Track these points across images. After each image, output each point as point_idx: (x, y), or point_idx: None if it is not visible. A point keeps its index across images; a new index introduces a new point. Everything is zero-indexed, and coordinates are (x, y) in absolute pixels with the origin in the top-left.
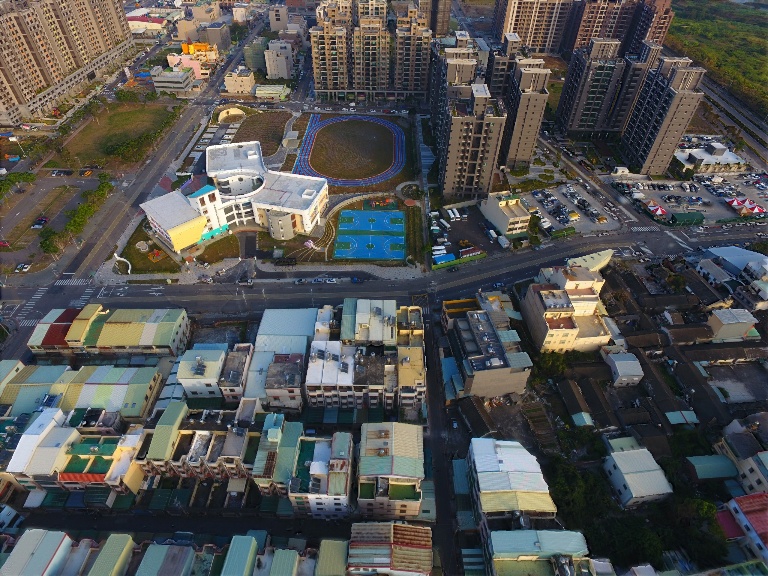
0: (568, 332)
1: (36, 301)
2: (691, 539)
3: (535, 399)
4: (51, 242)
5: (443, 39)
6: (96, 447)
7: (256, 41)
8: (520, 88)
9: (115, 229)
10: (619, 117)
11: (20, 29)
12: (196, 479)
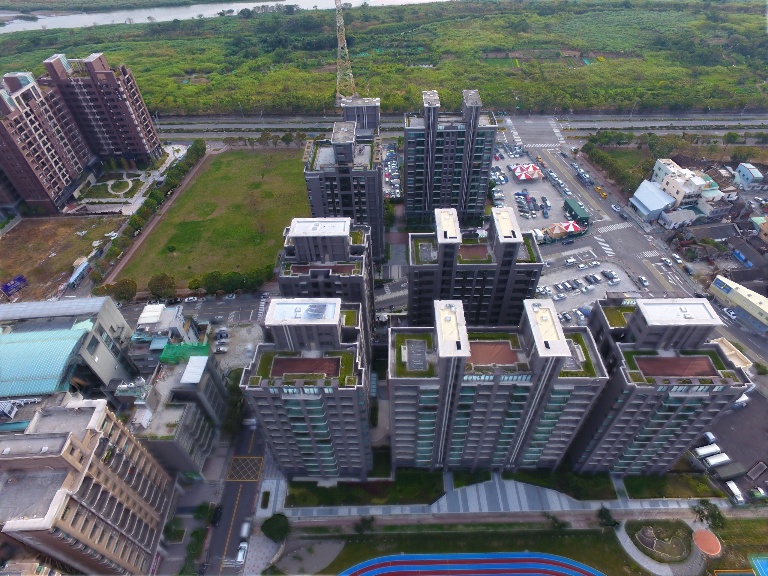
0: None
1: None
2: None
3: None
4: None
5: None
6: None
7: None
8: (515, 263)
9: None
10: None
11: None
12: None
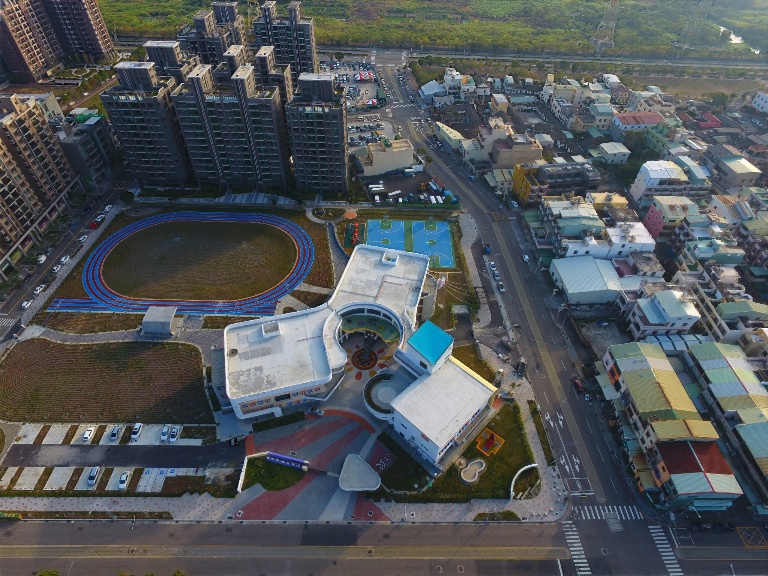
0: None
1: None
2: (640, 145)
3: None
4: None
5: None
6: None
7: None
8: (269, 73)
9: (431, 543)
10: None
11: None
12: None
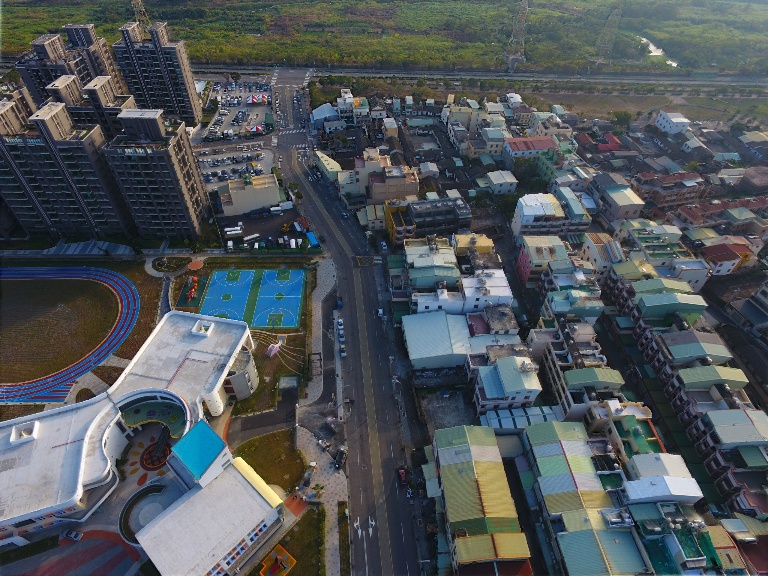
0: None
1: None
2: (530, 172)
3: None
4: None
5: None
6: None
7: None
8: (104, 107)
9: None
10: None
11: None
12: None
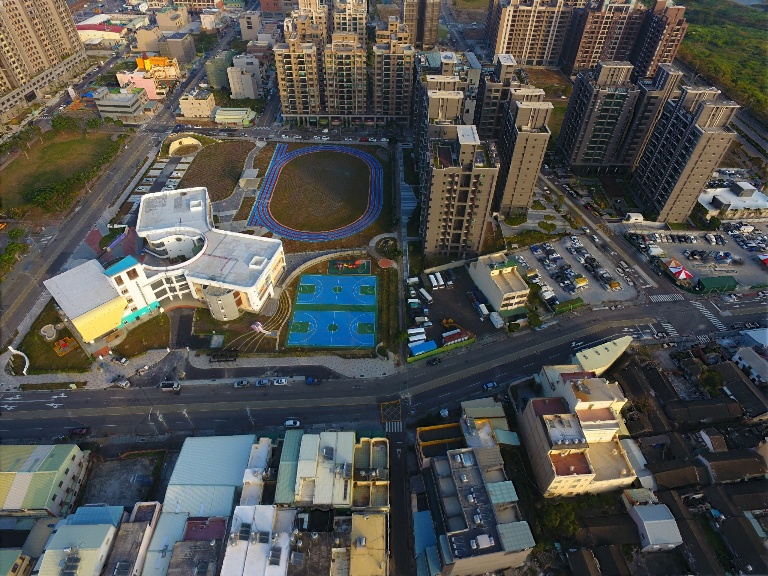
0: (581, 478)
1: None
2: None
3: (538, 575)
4: None
5: (429, 54)
6: None
7: (219, 56)
8: (516, 125)
9: (20, 306)
10: (630, 150)
11: None
12: None
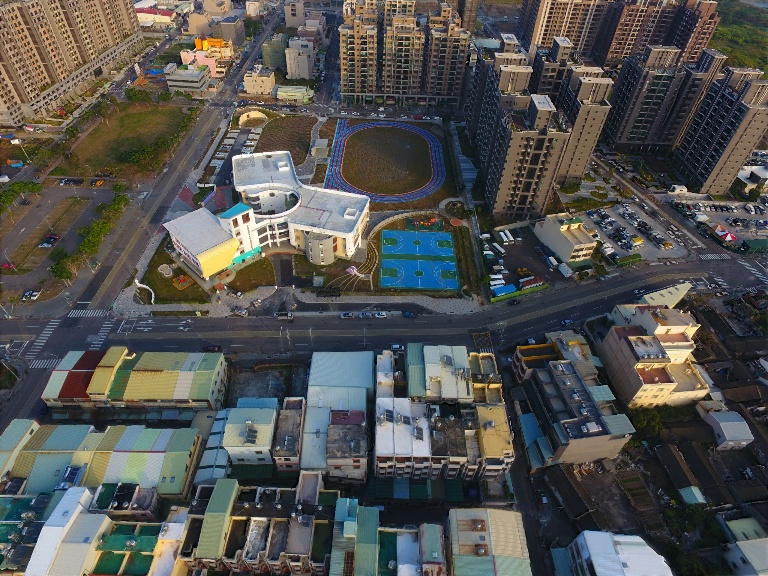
0: (664, 387)
1: (48, 336)
2: None
3: (630, 465)
4: (63, 266)
5: (476, 40)
6: (133, 542)
7: (275, 38)
8: (578, 99)
9: (133, 249)
10: (672, 130)
11: (23, 21)
12: (249, 572)
